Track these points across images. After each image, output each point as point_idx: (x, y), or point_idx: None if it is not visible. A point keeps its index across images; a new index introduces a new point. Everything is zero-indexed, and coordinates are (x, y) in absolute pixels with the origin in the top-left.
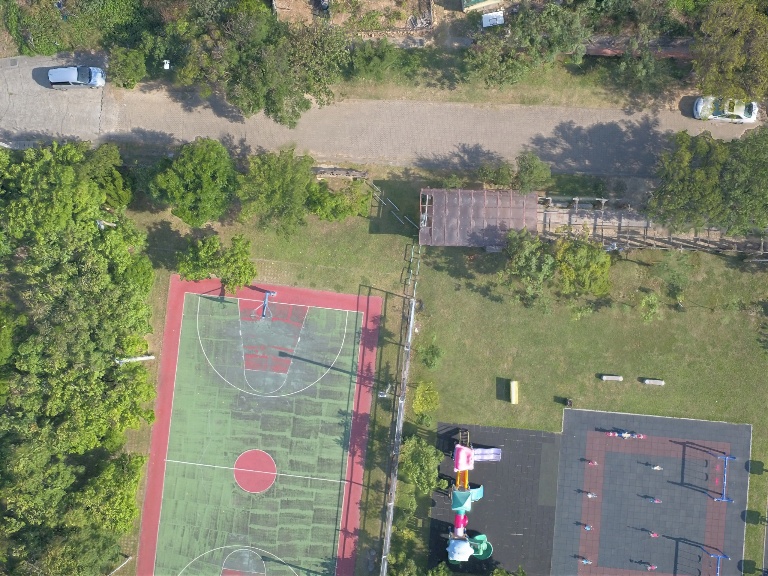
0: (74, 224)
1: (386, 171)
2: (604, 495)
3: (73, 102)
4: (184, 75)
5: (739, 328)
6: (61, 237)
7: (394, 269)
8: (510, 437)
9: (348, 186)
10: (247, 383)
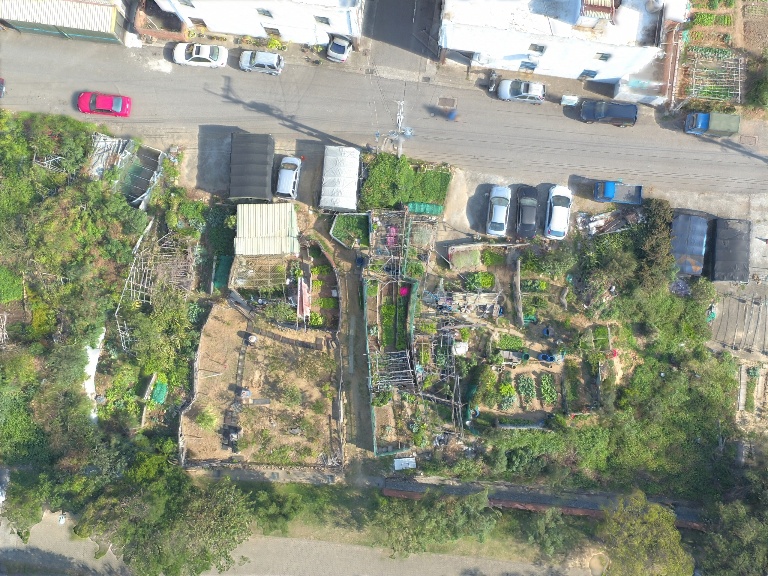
0: None
1: None
2: None
3: None
4: (80, 534)
5: None
6: None
7: None
8: None
9: None
10: None
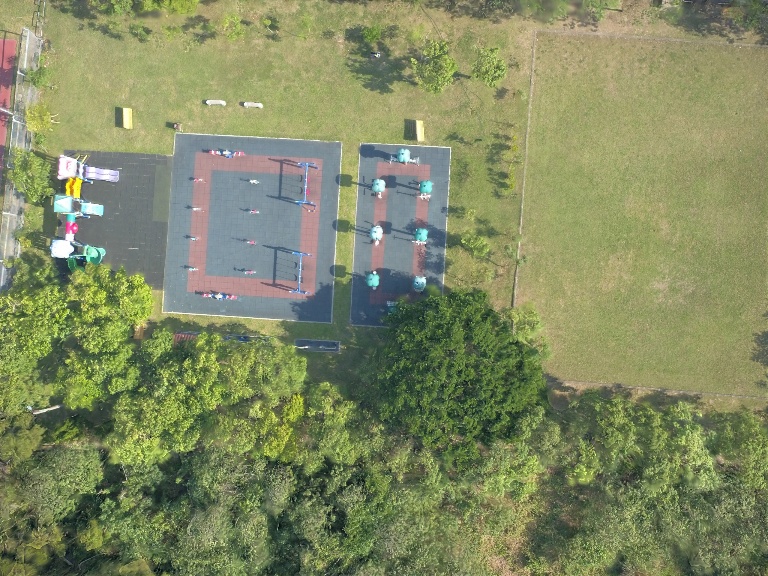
0: None
1: None
2: (211, 210)
3: None
4: None
5: (329, 54)
6: None
7: (26, 13)
8: (128, 161)
9: None
10: None
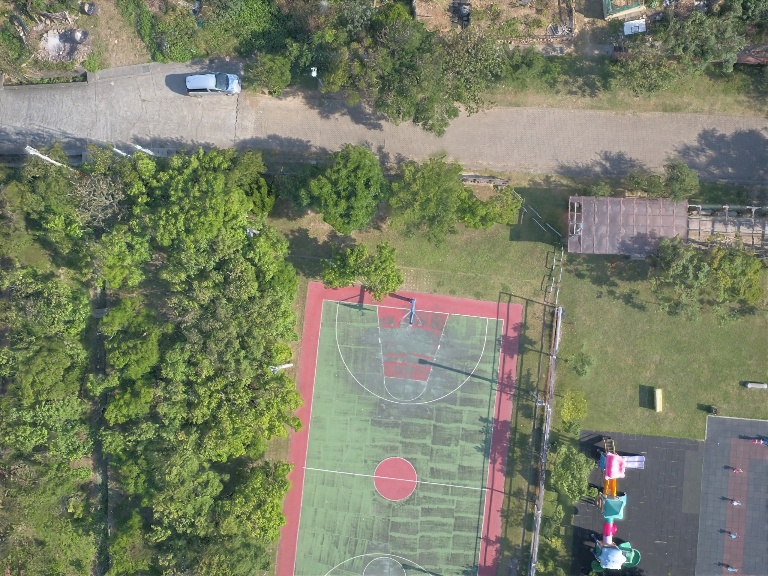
0: (225, 232)
1: (527, 178)
2: (748, 502)
3: (208, 109)
4: (333, 82)
5: None
6: (211, 245)
7: (535, 276)
8: (653, 444)
9: (489, 193)
10: (387, 390)
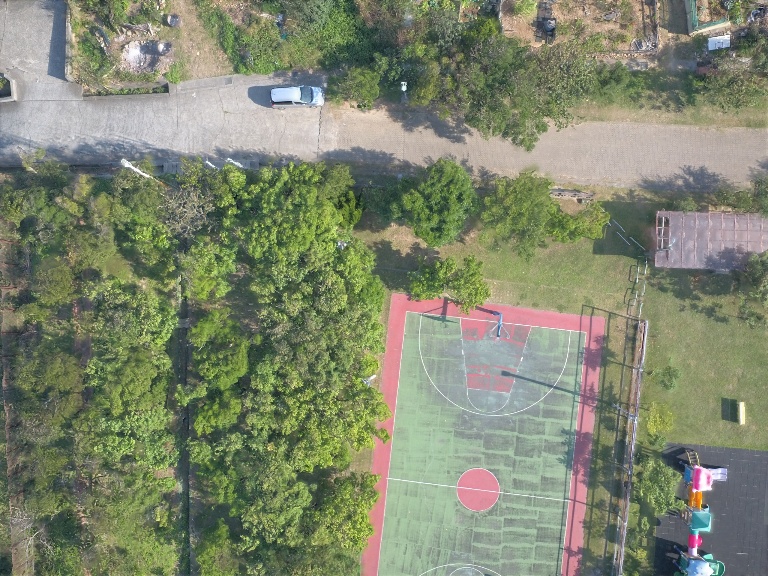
0: (317, 245)
1: (611, 192)
2: None
3: (291, 121)
4: (423, 97)
5: None
6: (303, 257)
7: (618, 290)
8: (735, 457)
9: (572, 207)
10: (470, 402)
